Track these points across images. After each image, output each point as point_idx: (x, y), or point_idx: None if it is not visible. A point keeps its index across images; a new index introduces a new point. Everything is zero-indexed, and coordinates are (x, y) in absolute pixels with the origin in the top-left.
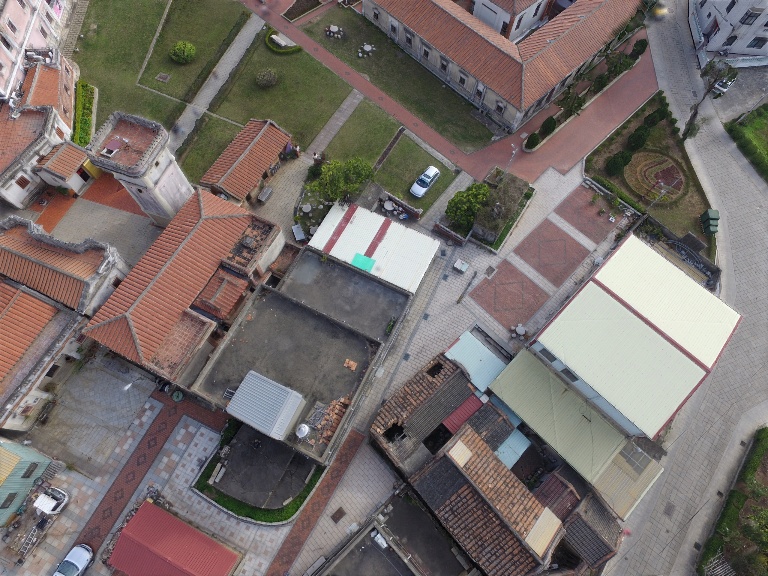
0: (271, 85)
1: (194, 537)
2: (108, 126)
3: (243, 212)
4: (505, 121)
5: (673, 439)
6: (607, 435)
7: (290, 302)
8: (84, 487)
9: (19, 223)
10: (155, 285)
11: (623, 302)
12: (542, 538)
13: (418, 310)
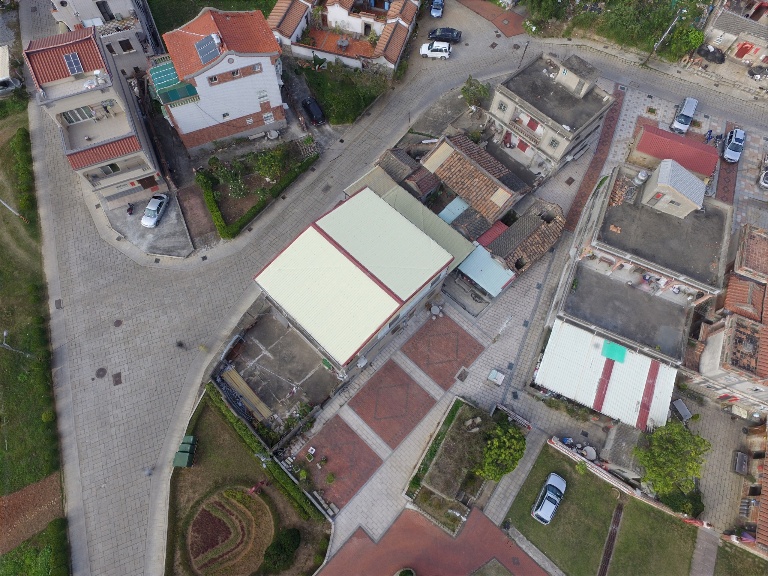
0: None
1: (669, 158)
2: None
3: None
4: None
5: None
6: None
7: None
8: (752, 193)
9: None
10: None
11: (377, 280)
12: (441, 153)
13: (534, 330)
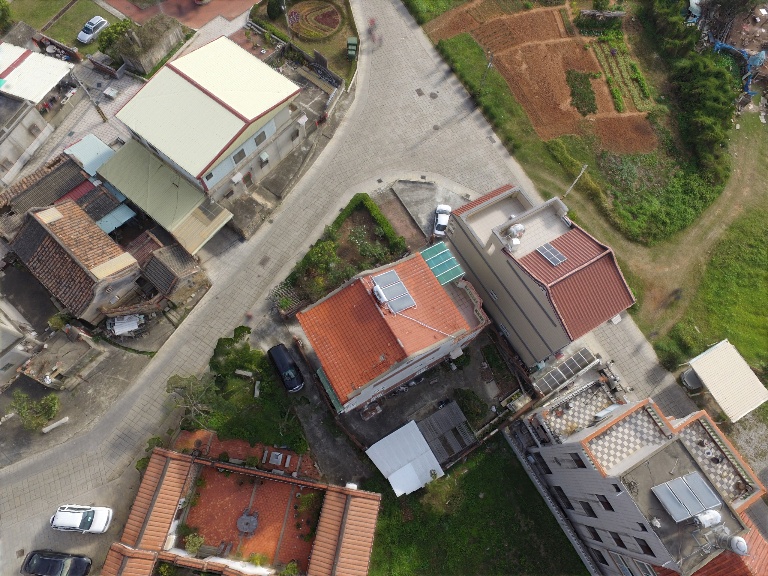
0: None
1: None
2: None
3: None
4: None
5: (281, 211)
6: (190, 195)
7: None
8: None
9: None
10: None
11: (188, 78)
12: (109, 269)
13: (65, 129)
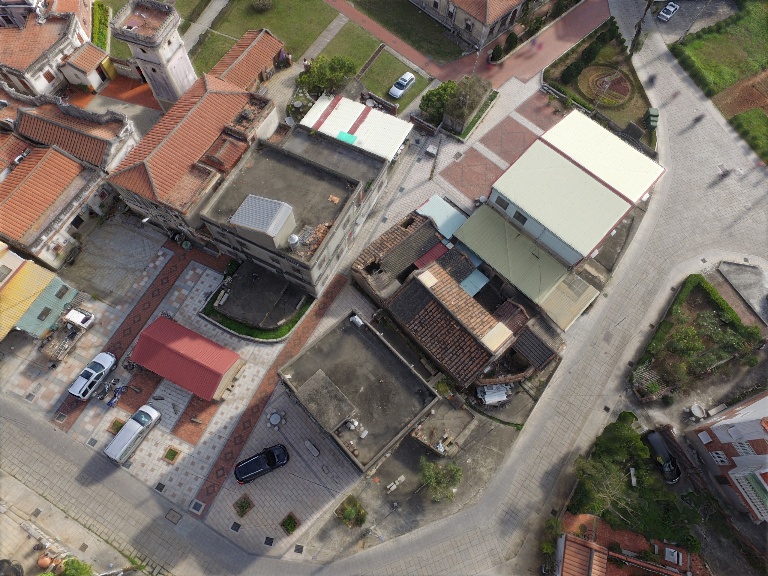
0: (266, 9)
1: (202, 341)
2: (128, 8)
3: (242, 91)
4: (473, 39)
5: (613, 285)
6: (552, 268)
7: (283, 154)
8: (107, 313)
9: (48, 101)
10: (168, 141)
11: (564, 154)
12: (495, 340)
13: (395, 185)
